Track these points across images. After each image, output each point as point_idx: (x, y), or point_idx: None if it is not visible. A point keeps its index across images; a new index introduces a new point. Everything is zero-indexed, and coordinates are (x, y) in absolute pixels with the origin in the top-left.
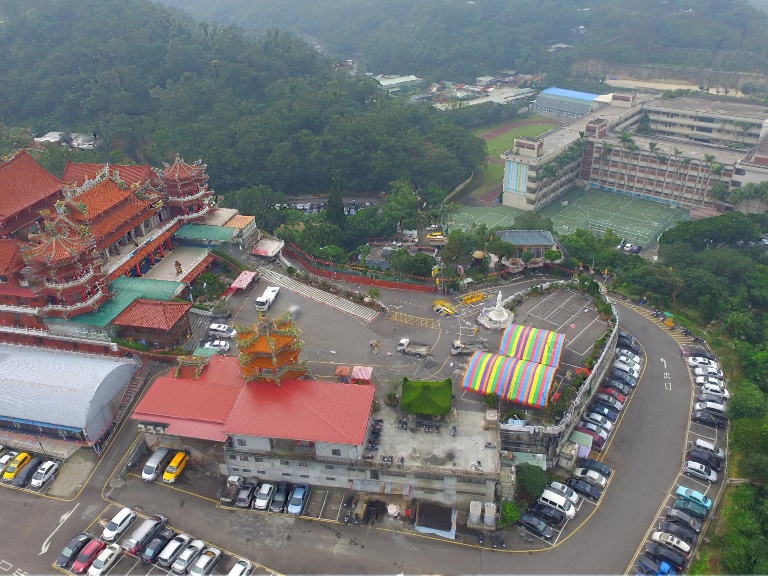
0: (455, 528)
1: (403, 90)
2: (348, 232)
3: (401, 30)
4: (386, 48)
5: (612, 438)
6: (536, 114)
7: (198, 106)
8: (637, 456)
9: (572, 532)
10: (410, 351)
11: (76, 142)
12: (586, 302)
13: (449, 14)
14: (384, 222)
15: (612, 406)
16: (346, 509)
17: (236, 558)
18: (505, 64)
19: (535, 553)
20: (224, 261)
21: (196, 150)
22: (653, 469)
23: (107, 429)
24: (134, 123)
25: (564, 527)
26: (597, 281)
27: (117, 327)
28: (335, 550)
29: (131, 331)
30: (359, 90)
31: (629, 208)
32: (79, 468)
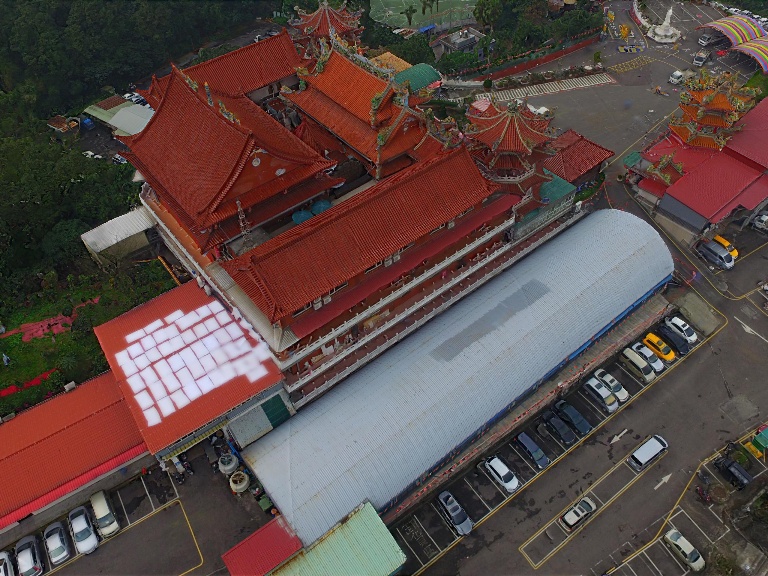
0: None
1: None
2: None
3: None
4: None
5: None
6: None
7: None
8: None
9: None
10: None
11: None
12: None
13: None
14: None
15: None
16: None
17: None
18: None
19: None
20: (444, 105)
21: None
22: None
23: None
24: None
25: None
26: None
27: None
28: None
29: None
30: None
31: None
32: (692, 303)
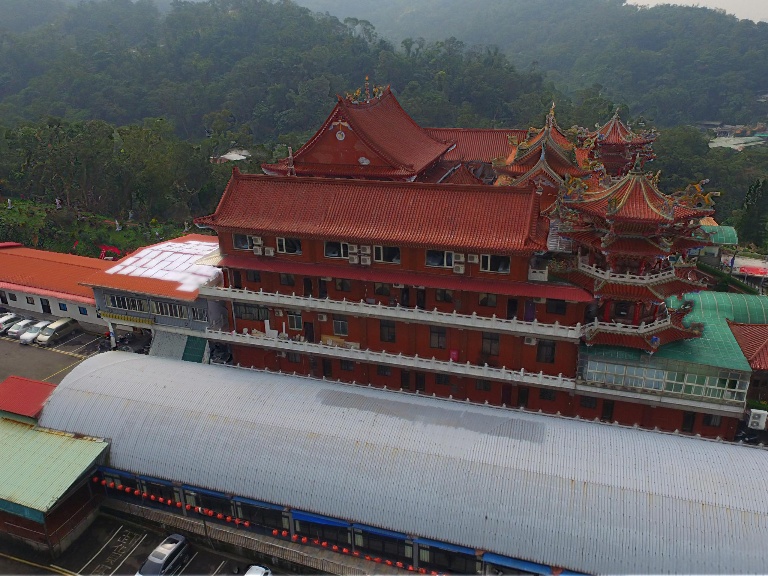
0: None
1: None
2: None
3: (569, 80)
4: None
5: None
6: None
7: (430, 119)
8: None
9: None
10: None
11: None
12: None
13: (635, 61)
14: None
15: None
16: None
17: None
18: (702, 115)
19: None
20: (726, 278)
21: None
22: None
23: None
24: None
25: None
26: None
27: None
28: None
29: None
30: None
31: None
32: None
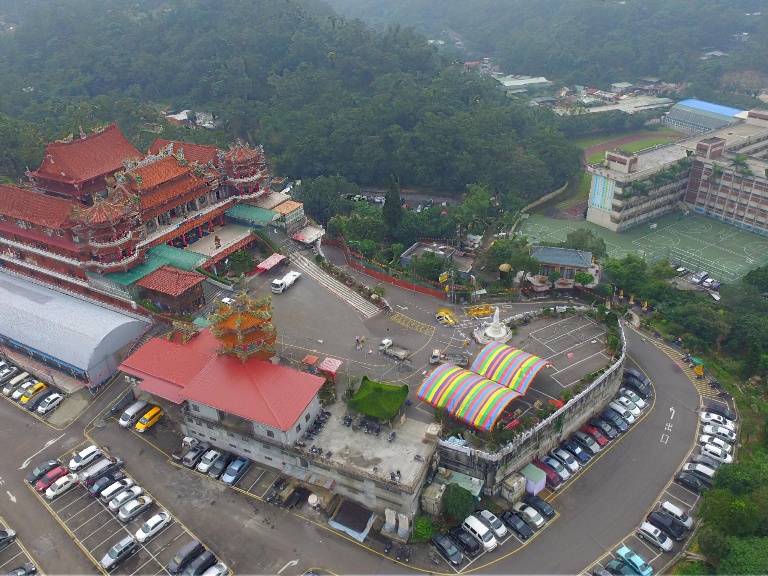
0: (368, 531)
1: (529, 92)
2: (399, 229)
3: (543, 30)
4: (521, 48)
5: (574, 480)
6: (667, 127)
7: (307, 95)
8: (592, 504)
9: (484, 564)
10: (390, 352)
11: (200, 121)
12: (599, 333)
13: (594, 15)
14: (445, 224)
15: (587, 447)
16: (274, 489)
17: (162, 510)
18: (649, 70)
19: (436, 575)
20: (261, 242)
21: (296, 136)
22: (604, 522)
23: (110, 375)
24: (248, 107)
25: (478, 557)
26: (634, 313)
27: (140, 288)
28: (247, 524)
29: (151, 293)
30: (465, 89)
31: (731, 240)
32: (76, 404)
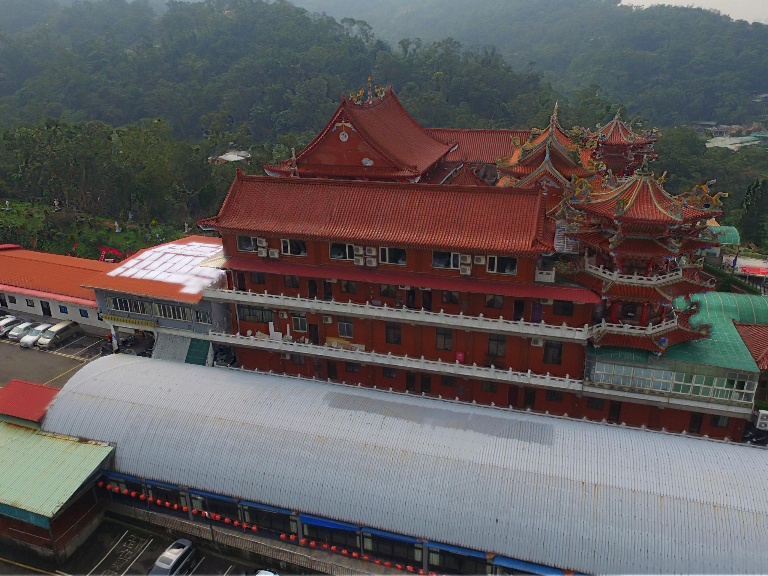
0: None
1: None
2: None
3: (565, 80)
4: None
5: None
6: None
7: (428, 120)
8: None
9: None
10: None
11: None
12: None
13: (631, 61)
14: None
15: None
16: None
17: None
18: (698, 115)
19: None
20: (728, 279)
21: None
22: None
23: None
24: None
25: None
26: None
27: None
28: None
29: None
30: None
31: None
32: None
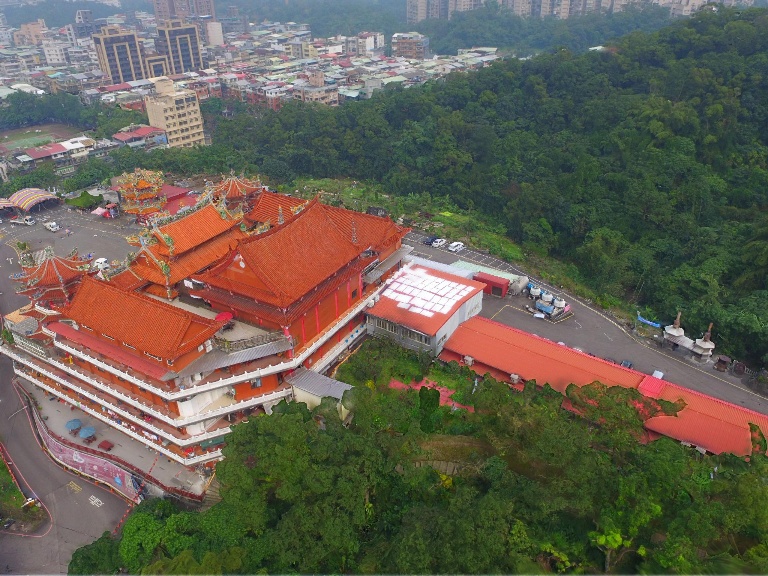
0: None
1: None
2: None
3: None
4: None
5: None
6: None
7: None
8: None
9: None
10: None
11: None
12: None
13: None
14: None
15: None
16: None
17: None
18: None
19: None
20: None
21: None
22: None
23: None
24: None
25: None
26: None
27: None
28: None
29: None
30: None
31: None
32: None
